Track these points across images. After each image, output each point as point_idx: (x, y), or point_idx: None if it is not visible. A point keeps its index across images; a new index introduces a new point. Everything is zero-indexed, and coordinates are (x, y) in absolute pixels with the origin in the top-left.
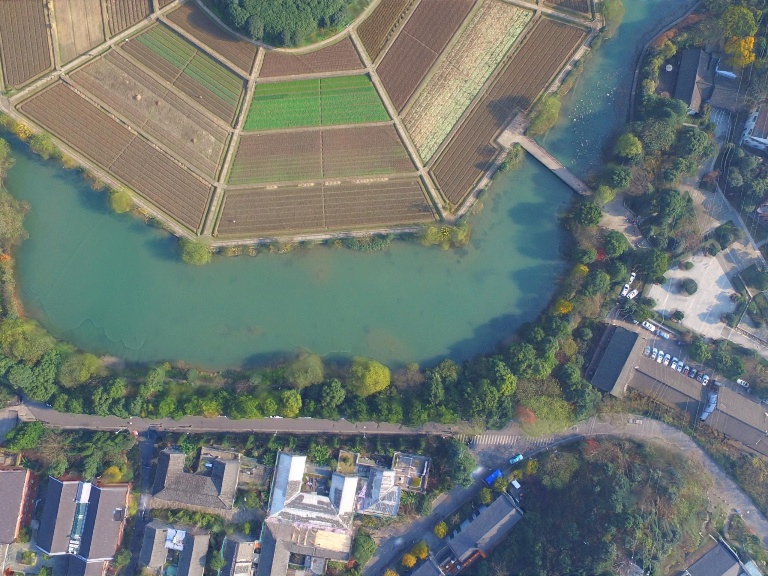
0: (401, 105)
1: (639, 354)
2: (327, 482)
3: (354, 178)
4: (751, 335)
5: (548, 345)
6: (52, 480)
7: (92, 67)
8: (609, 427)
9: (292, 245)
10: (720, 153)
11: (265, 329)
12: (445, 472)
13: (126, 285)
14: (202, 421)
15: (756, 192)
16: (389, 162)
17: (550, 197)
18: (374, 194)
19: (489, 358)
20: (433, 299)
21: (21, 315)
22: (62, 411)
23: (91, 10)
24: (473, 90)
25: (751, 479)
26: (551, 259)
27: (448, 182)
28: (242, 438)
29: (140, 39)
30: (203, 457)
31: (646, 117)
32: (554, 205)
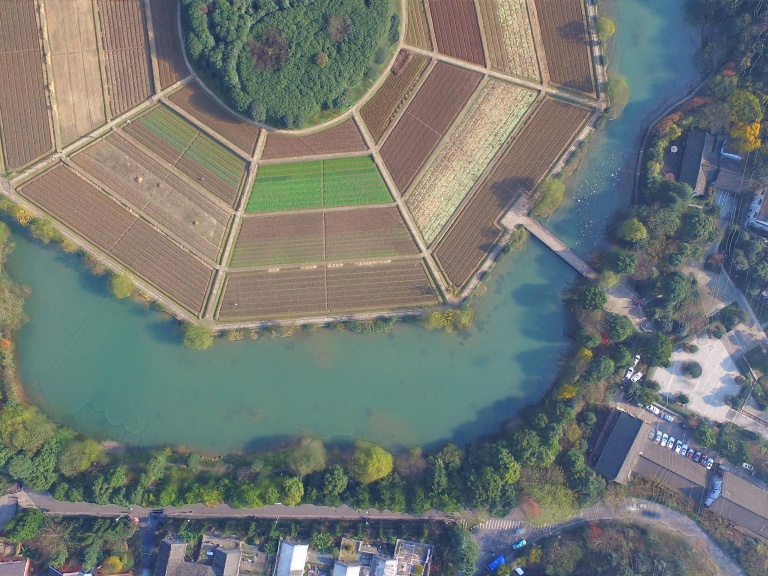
0: (404, 186)
1: (643, 440)
2: (329, 571)
3: (357, 260)
4: (756, 417)
5: (552, 433)
6: (52, 571)
7: (93, 149)
8: (613, 512)
9: (294, 328)
10: (725, 234)
11: (267, 412)
12: (448, 558)
13: (127, 368)
14: (203, 506)
15: (761, 276)
16: (392, 244)
17: (554, 278)
18: (377, 276)
19: (492, 444)
20: (436, 381)
21: (21, 401)
22: (62, 500)
23: (92, 91)
24: (477, 171)
25: (756, 566)
26: (555, 341)
27: (451, 264)
28: (243, 525)
29: (142, 121)
30: (204, 545)
31: (651, 200)
32: (558, 286)
